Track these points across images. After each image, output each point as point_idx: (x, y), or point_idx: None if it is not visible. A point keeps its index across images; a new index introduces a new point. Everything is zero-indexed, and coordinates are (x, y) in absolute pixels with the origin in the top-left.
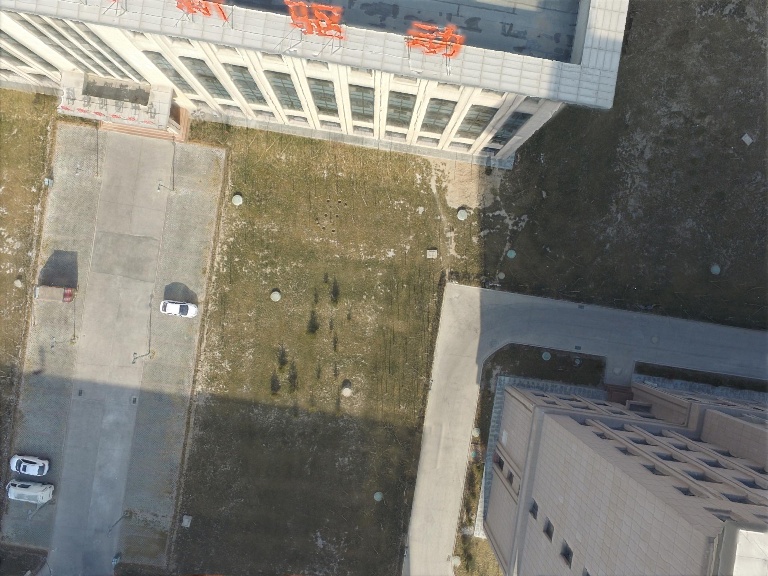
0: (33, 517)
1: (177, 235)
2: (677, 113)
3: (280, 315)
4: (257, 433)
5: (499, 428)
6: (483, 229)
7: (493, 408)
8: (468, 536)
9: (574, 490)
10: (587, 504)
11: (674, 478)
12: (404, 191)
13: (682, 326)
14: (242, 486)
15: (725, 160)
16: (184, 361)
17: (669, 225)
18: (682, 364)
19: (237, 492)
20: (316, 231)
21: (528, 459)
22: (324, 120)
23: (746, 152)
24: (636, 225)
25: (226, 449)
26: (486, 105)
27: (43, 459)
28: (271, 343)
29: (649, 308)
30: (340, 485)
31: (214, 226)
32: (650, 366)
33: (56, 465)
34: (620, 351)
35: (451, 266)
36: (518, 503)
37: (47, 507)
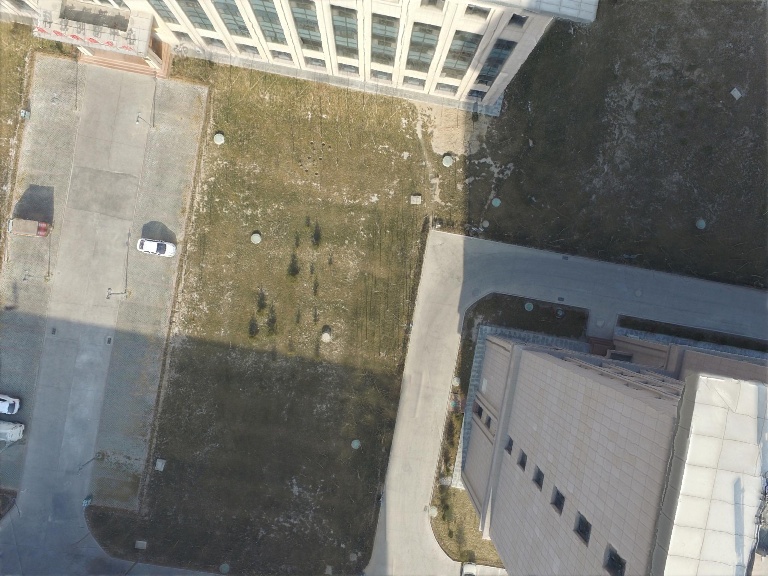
0: (2, 457)
1: (156, 173)
2: (667, 65)
3: (260, 258)
4: (234, 377)
5: (479, 378)
6: (468, 176)
7: (474, 358)
8: (445, 486)
9: (547, 414)
10: (559, 423)
11: (646, 391)
12: (389, 135)
13: (666, 280)
14: (217, 431)
15: (713, 114)
16: (161, 302)
17: (656, 178)
18: (665, 318)
19: (212, 437)
20: (299, 173)
21: (505, 397)
22: (309, 56)
23: (735, 107)
24: (622, 177)
25: (202, 393)
26: (470, 31)
27: (14, 397)
28: (250, 286)
29: (633, 257)
30: (317, 432)
31: (195, 165)
32: (633, 319)
33: (27, 404)
34: (603, 304)
35: (435, 213)
36: (494, 442)
37: (17, 447)
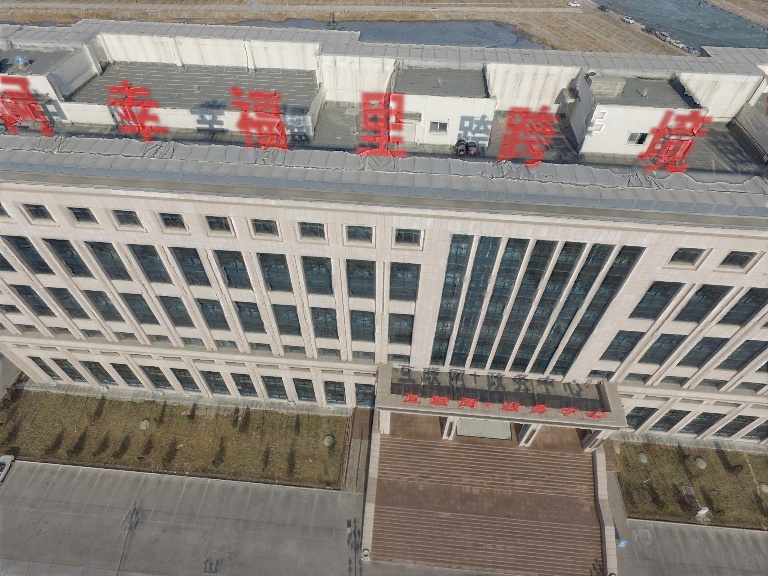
0: None
1: None
2: None
3: None
4: None
5: None
6: None
7: None
8: (19, 390)
9: None
10: None
11: None
12: None
13: None
14: None
15: None
16: None
17: None
18: None
19: None
20: None
21: None
22: None
23: None
24: None
25: None
26: None
27: None
28: None
29: None
30: None
31: None
32: None
33: None
34: None
35: None
36: None
37: None
